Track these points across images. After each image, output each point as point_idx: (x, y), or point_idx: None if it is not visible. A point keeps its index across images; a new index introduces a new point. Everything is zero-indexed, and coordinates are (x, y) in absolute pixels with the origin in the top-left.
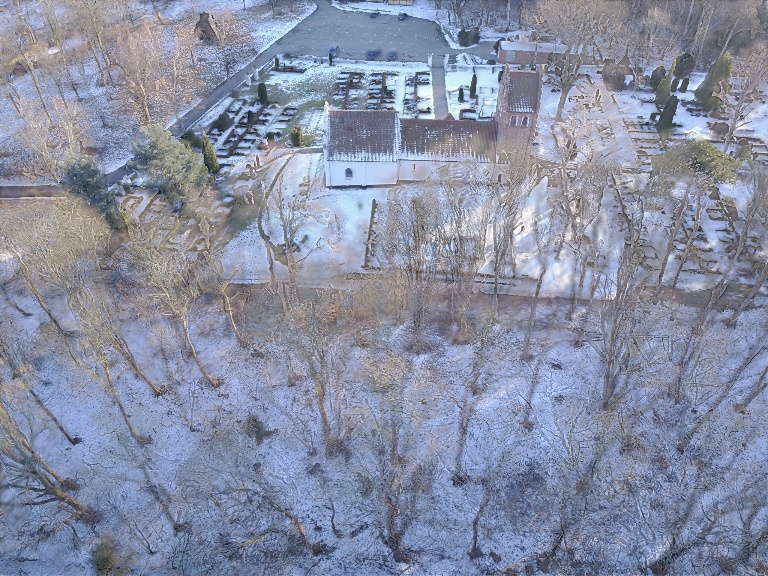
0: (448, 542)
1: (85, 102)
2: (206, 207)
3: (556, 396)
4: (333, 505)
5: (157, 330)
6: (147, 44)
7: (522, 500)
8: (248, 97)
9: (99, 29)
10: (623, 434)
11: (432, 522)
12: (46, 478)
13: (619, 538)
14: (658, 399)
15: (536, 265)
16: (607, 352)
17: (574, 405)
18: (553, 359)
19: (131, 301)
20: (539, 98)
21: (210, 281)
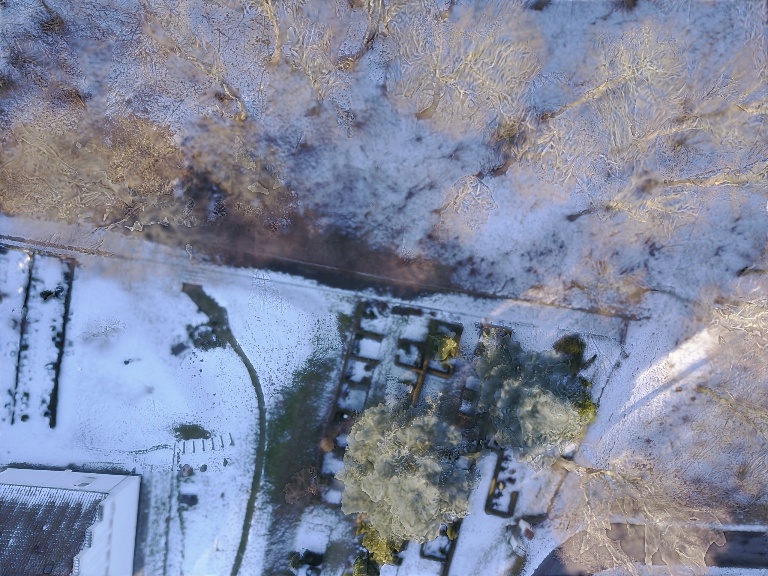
0: None
1: None
2: None
3: None
4: None
5: None
6: None
7: None
8: None
9: None
10: None
11: None
12: None
13: None
14: None
15: None
16: None
17: None
18: None
19: None
20: None
21: None
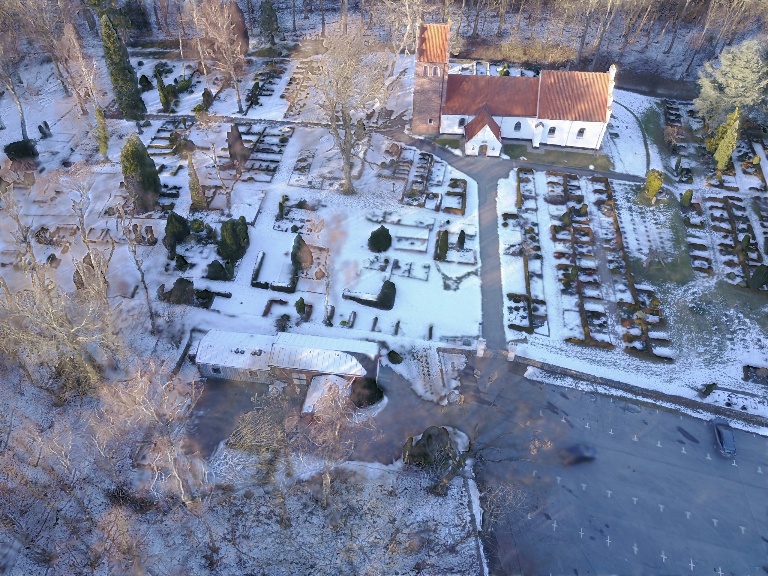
0: None
1: None
2: None
3: None
4: None
5: None
6: None
7: None
8: None
9: None
10: None
11: None
12: None
13: None
14: None
15: None
16: None
17: None
18: None
19: None
20: None
21: None
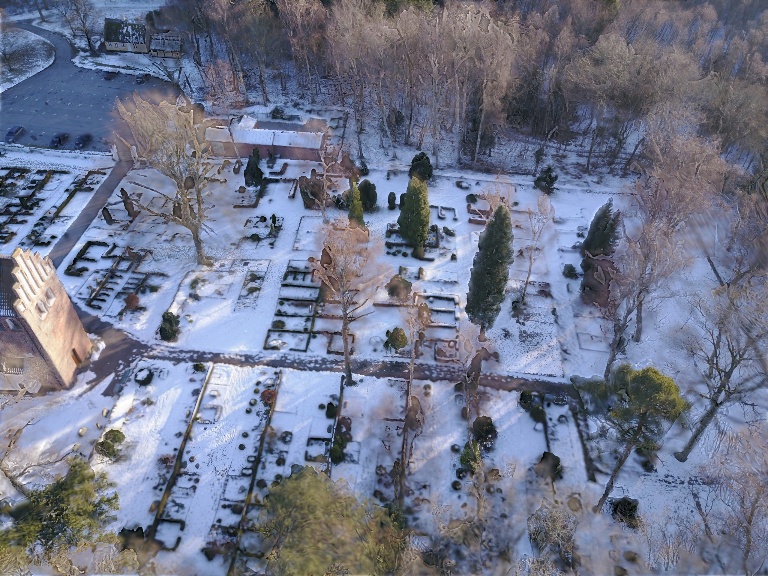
0: None
1: None
2: None
3: None
4: None
5: None
6: None
7: None
8: None
9: None
10: None
11: None
12: None
13: None
14: None
15: None
16: None
17: None
18: None
19: None
20: (17, 297)
21: None
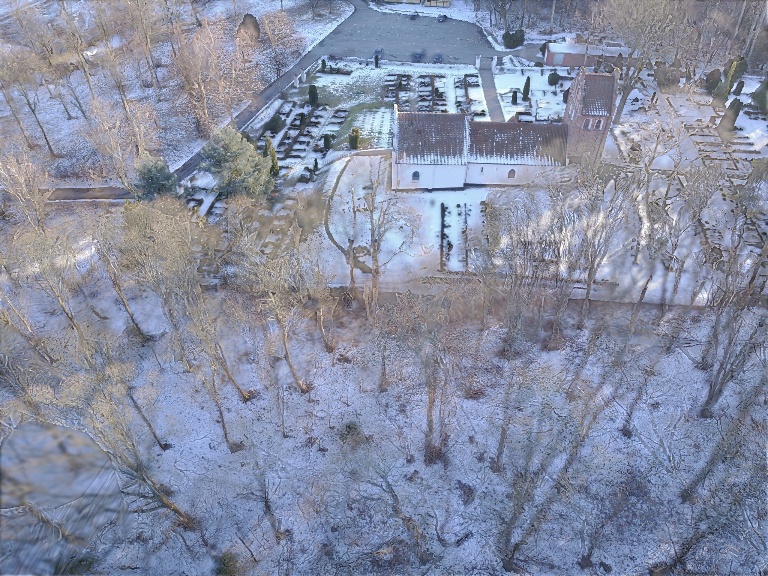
0: (556, 551)
1: (133, 104)
2: (268, 210)
3: (652, 403)
4: (436, 513)
5: (255, 335)
6: (208, 46)
7: (627, 509)
8: (297, 99)
9: (148, 30)
10: (723, 442)
11: (538, 531)
12: (152, 485)
13: (729, 548)
14: (755, 406)
15: (614, 270)
16: (718, 359)
17: (672, 412)
18: (645, 365)
19: (232, 306)
20: (614, 101)
21: (318, 286)
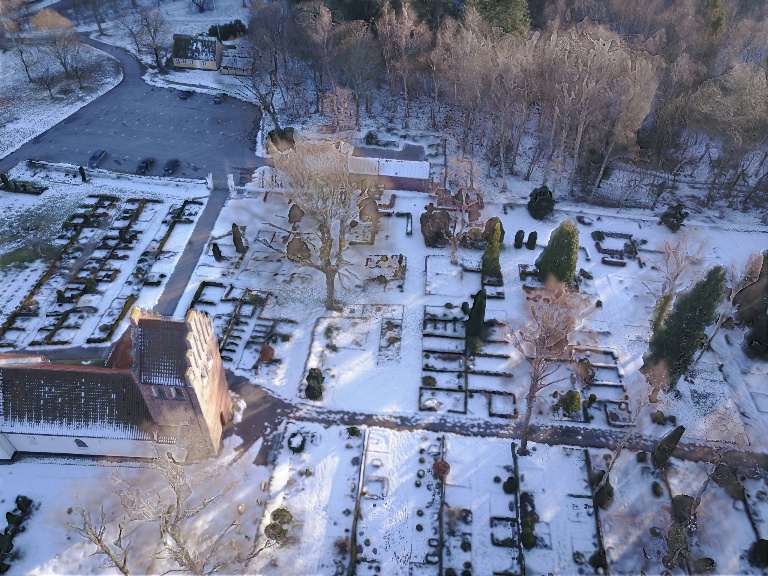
0: None
1: None
2: None
3: None
4: None
5: None
6: None
7: None
8: None
9: None
10: None
11: None
12: None
13: None
14: None
15: None
16: None
17: None
18: None
19: None
20: (188, 365)
21: None
